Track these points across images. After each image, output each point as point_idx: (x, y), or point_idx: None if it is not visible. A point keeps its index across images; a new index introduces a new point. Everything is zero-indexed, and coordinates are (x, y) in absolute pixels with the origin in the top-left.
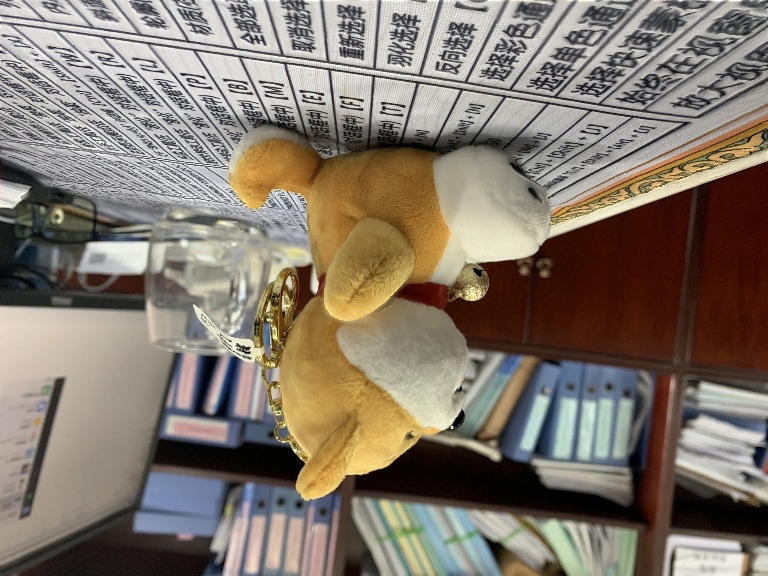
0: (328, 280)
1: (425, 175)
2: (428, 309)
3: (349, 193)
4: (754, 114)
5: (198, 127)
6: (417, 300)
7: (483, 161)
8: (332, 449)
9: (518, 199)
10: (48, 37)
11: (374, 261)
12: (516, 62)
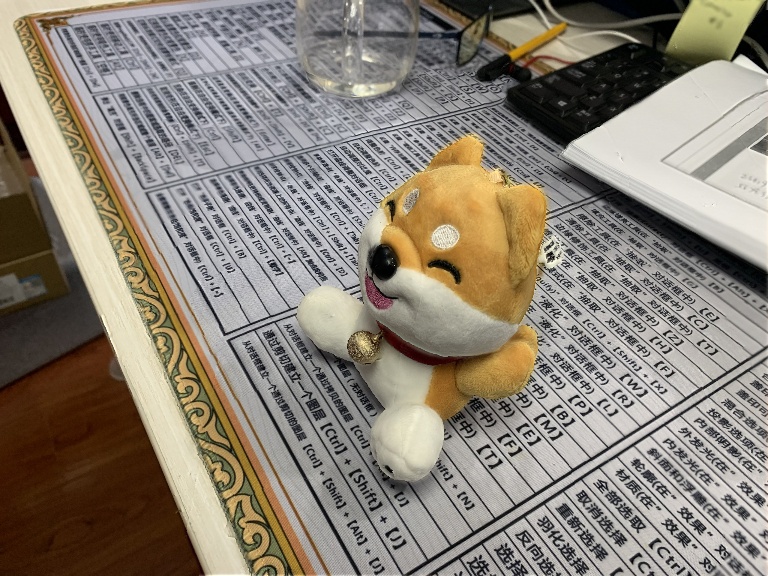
0: None
1: None
2: None
3: None
4: None
5: (529, 325)
6: None
7: None
8: None
9: None
10: (655, 406)
11: None
12: (513, 575)
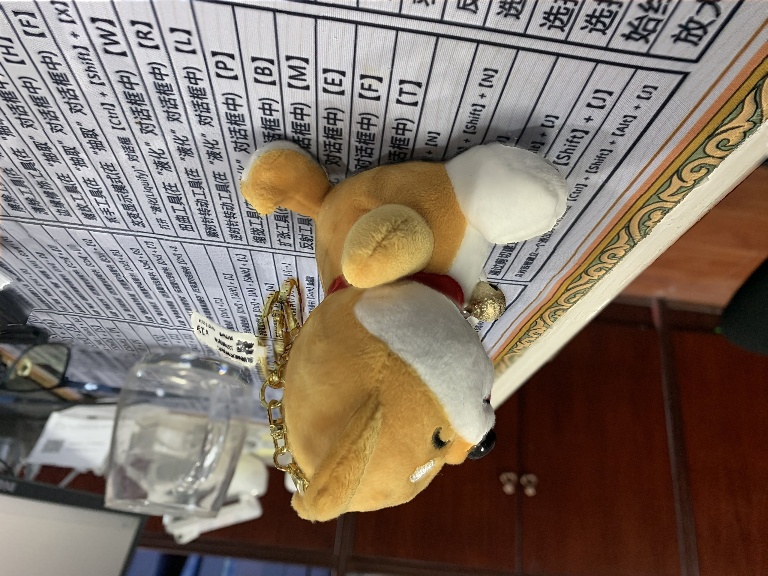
0: (347, 242)
1: (438, 171)
2: (449, 300)
3: (364, 188)
4: (747, 52)
5: (210, 161)
6: (437, 289)
7: (496, 147)
8: (350, 433)
9: (536, 164)
10: None
11: (396, 218)
12: None
